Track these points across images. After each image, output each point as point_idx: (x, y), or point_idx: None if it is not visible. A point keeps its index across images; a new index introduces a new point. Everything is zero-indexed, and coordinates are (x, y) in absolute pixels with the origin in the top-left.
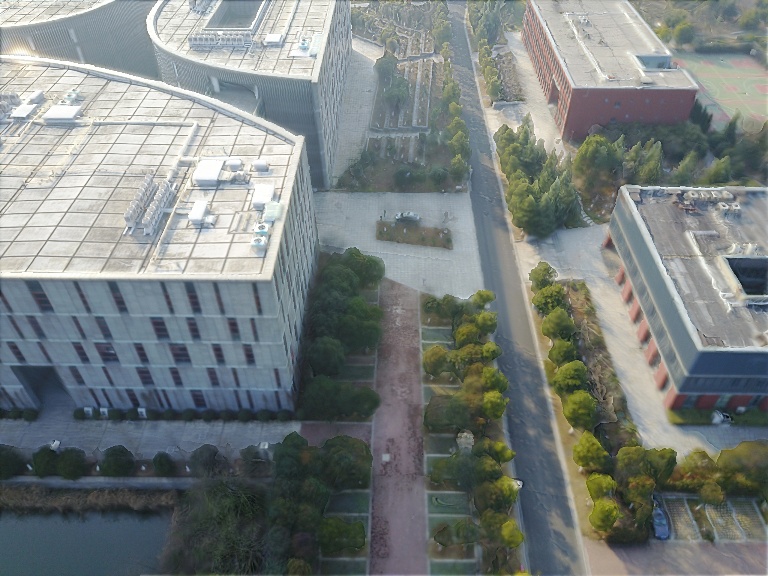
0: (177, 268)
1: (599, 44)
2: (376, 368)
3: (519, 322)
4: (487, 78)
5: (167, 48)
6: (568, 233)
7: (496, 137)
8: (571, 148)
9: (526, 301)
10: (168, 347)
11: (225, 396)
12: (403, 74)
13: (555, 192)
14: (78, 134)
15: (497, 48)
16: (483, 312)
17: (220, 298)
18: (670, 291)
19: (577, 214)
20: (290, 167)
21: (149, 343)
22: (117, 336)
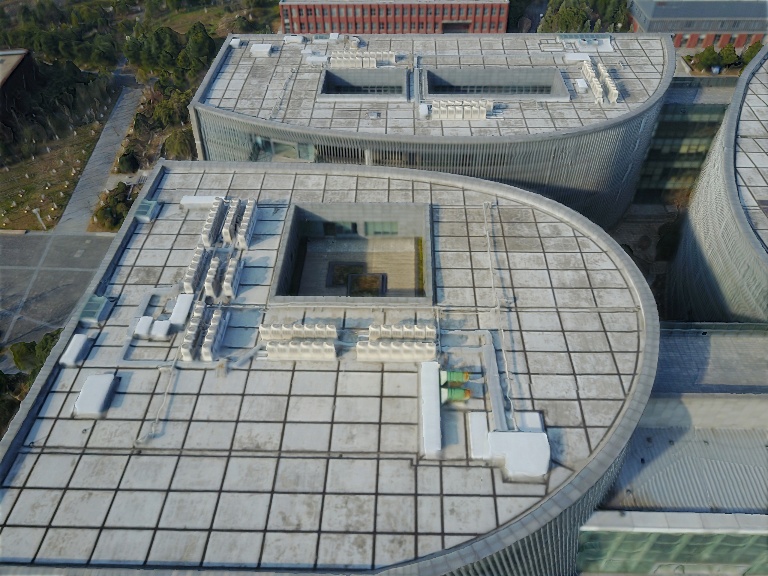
0: None
1: None
2: None
3: None
4: None
5: (644, 107)
6: None
7: None
8: None
9: None
10: None
11: None
12: None
13: None
14: None
15: None
16: None
17: None
18: (752, 0)
19: None
20: None
21: None
22: None
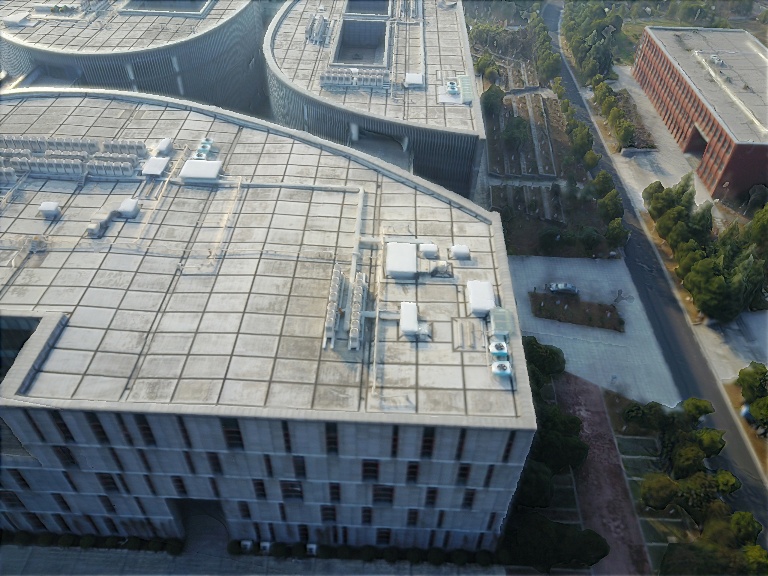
0: (407, 403)
1: (744, 89)
2: (576, 491)
3: (729, 433)
4: (613, 121)
5: (298, 88)
6: (754, 317)
7: (646, 194)
8: (724, 208)
9: (729, 404)
10: (371, 488)
11: (417, 535)
12: (512, 110)
13: (746, 271)
14: (225, 199)
15: (608, 84)
16: (706, 429)
17: (462, 444)
18: None
19: (759, 293)
20: (498, 256)
21: (349, 483)
22: (312, 476)
